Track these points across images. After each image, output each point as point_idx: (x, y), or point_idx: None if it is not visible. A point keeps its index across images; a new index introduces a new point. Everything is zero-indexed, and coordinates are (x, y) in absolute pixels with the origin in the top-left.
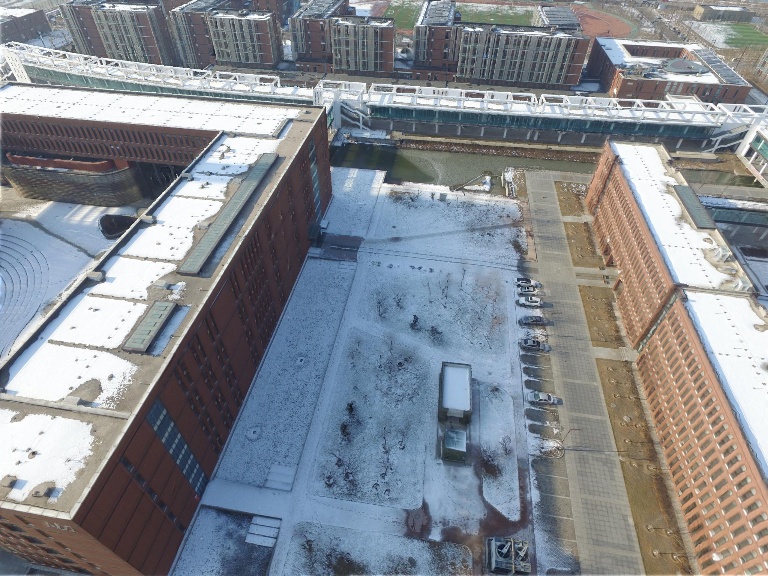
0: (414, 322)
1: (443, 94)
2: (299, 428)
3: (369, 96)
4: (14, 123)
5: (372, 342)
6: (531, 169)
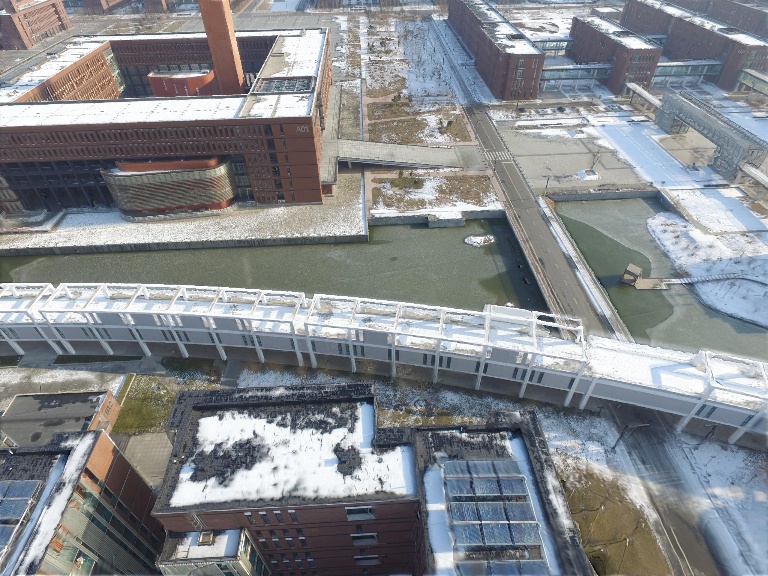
0: None
1: None
2: None
3: None
4: None
5: None
6: None
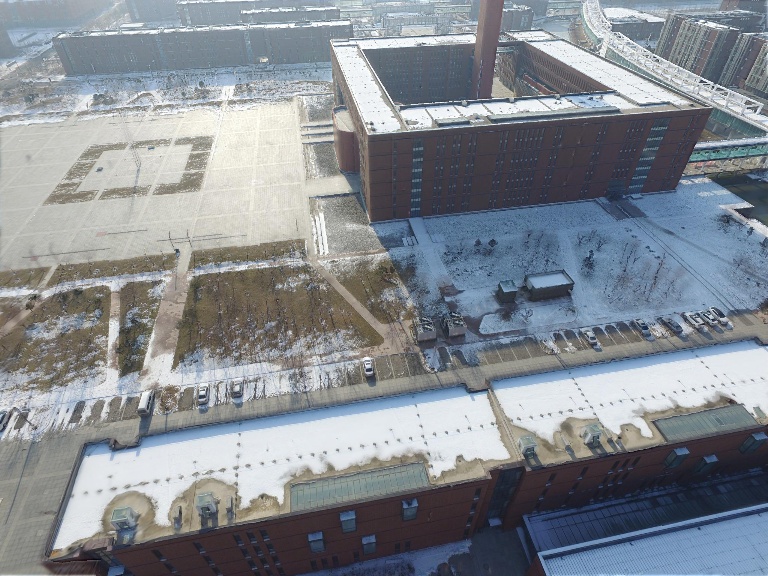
0: (589, 256)
1: None
2: (469, 236)
3: None
4: (537, 56)
5: (553, 245)
6: None
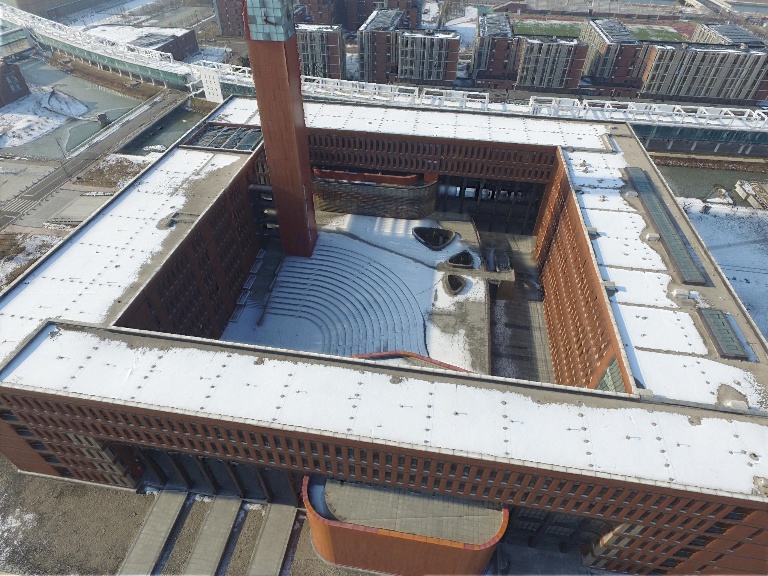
0: None
1: (655, 110)
2: None
3: (587, 112)
4: (336, 139)
5: None
6: (765, 182)
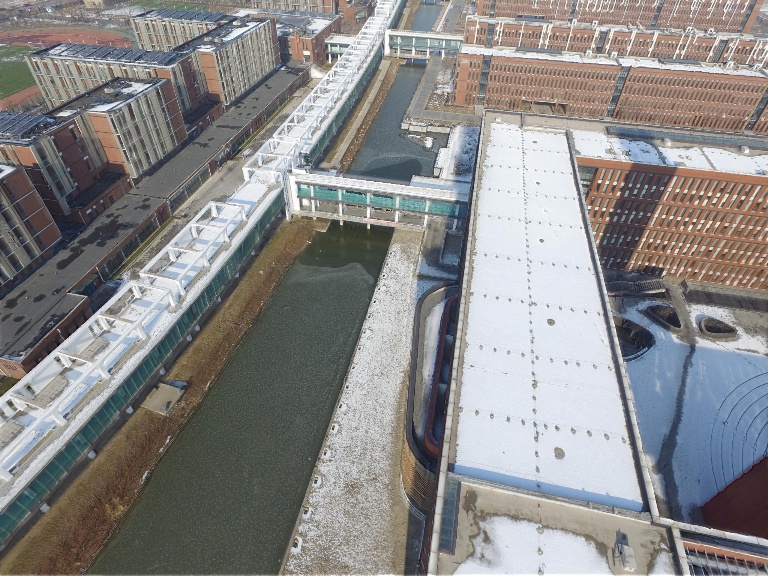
0: None
1: None
2: None
3: None
4: None
5: None
6: (406, 114)
